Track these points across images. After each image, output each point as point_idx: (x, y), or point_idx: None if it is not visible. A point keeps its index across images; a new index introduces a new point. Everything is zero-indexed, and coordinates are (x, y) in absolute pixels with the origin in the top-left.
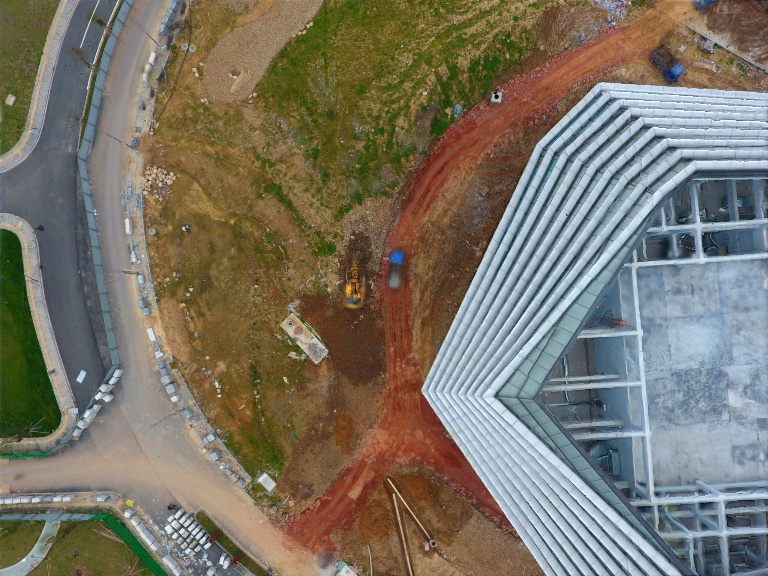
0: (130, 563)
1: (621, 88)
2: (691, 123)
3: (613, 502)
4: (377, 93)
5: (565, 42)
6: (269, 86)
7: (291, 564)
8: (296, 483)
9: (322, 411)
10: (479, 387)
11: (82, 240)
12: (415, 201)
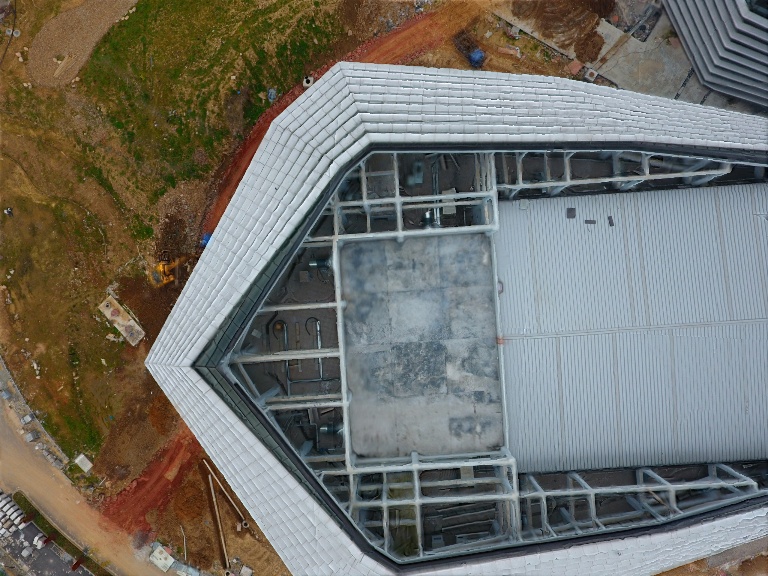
0: None
1: (360, 67)
2: (402, 99)
3: (293, 469)
4: (188, 77)
5: (373, 27)
6: (91, 71)
7: (107, 544)
8: (112, 464)
9: (139, 393)
10: (179, 357)
11: None
12: (232, 185)
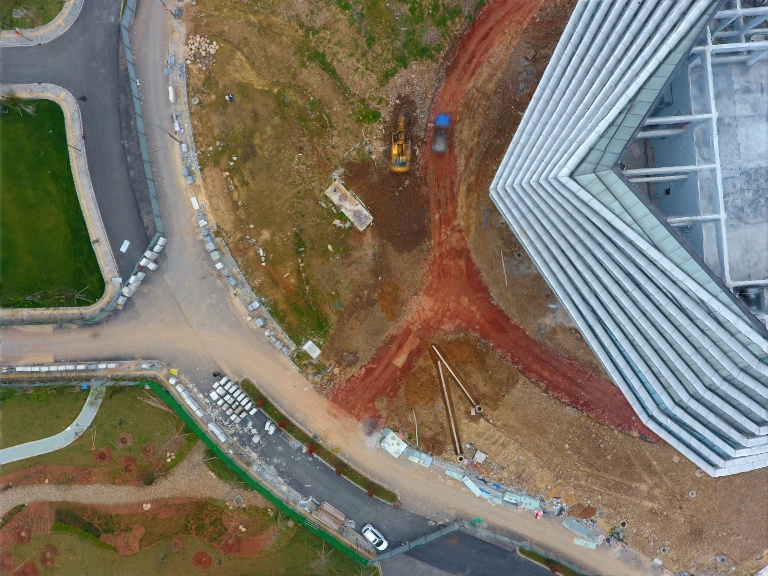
0: (176, 427)
1: None
2: None
3: (692, 272)
4: None
5: None
6: None
7: (336, 431)
8: (341, 350)
9: (367, 279)
10: (553, 169)
11: (125, 110)
12: (460, 67)
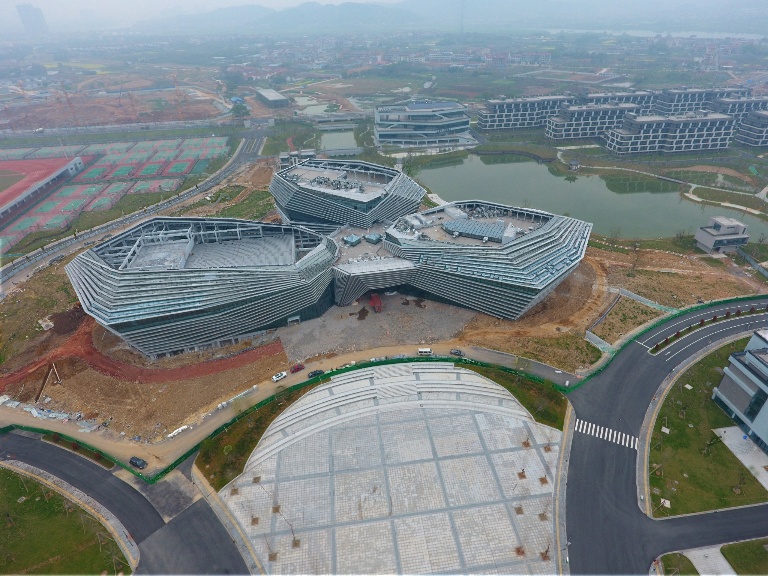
0: None
1: None
2: None
3: None
4: None
5: None
6: None
7: None
8: (3, 368)
9: (37, 344)
10: None
11: None
12: None
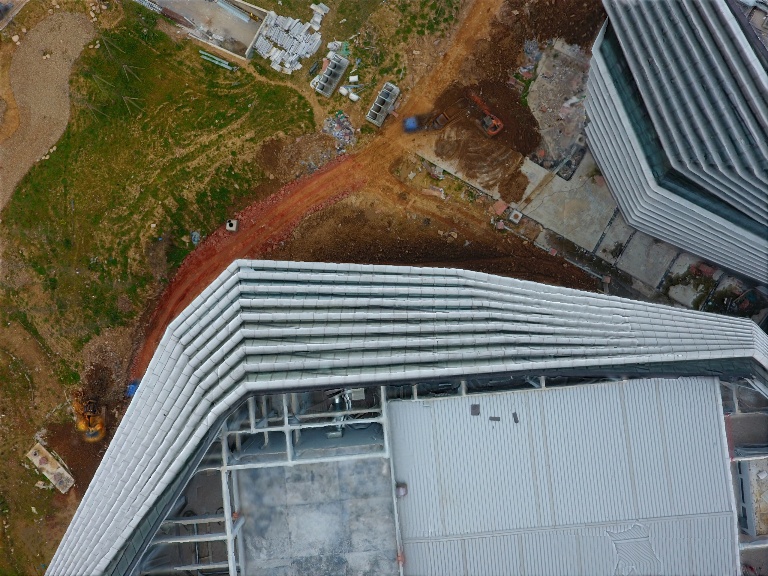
0: None
1: (258, 265)
2: (292, 317)
3: None
4: (109, 224)
5: (295, 170)
6: (12, 213)
7: None
8: None
9: None
10: None
11: None
12: (159, 327)
